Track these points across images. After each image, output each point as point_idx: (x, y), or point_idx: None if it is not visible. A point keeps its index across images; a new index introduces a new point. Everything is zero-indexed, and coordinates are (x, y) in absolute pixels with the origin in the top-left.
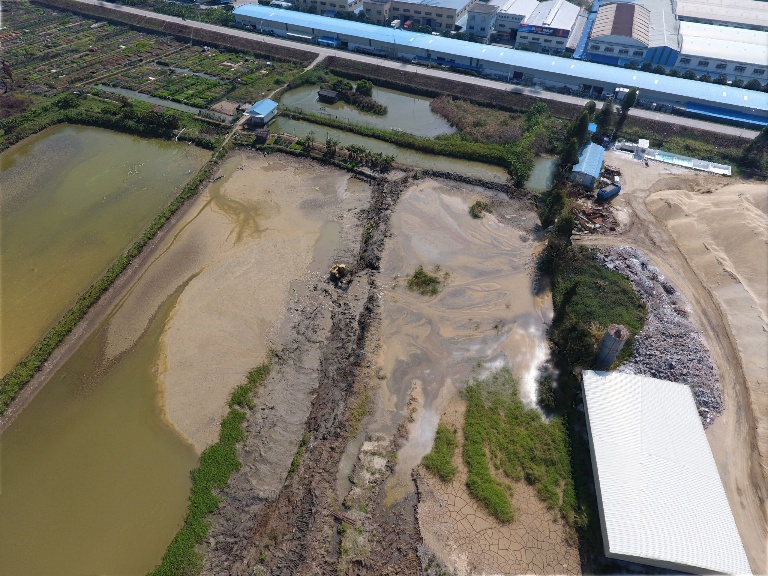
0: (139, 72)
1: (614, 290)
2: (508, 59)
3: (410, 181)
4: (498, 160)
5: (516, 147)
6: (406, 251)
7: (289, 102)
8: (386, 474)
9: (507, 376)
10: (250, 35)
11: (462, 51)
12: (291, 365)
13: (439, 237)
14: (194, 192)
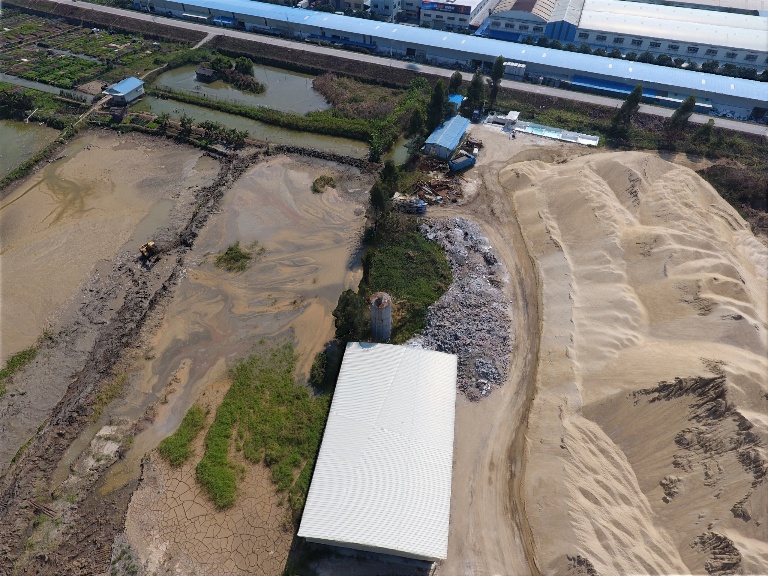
0: (14, 54)
1: (423, 260)
2: (400, 35)
3: (260, 157)
4: (363, 135)
5: (381, 121)
6: (228, 227)
7: (168, 82)
8: (112, 460)
9: (287, 353)
10: (142, 16)
11: (355, 28)
12: (62, 348)
13: (269, 212)
14: (26, 172)
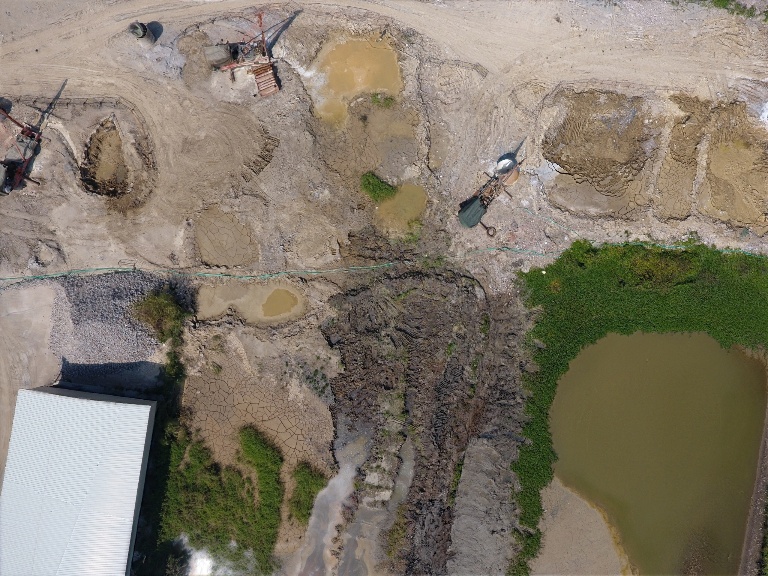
0: None
1: None
2: None
3: None
4: None
5: None
6: None
7: None
8: (365, 467)
9: None
10: None
11: None
12: None
13: None
14: None
